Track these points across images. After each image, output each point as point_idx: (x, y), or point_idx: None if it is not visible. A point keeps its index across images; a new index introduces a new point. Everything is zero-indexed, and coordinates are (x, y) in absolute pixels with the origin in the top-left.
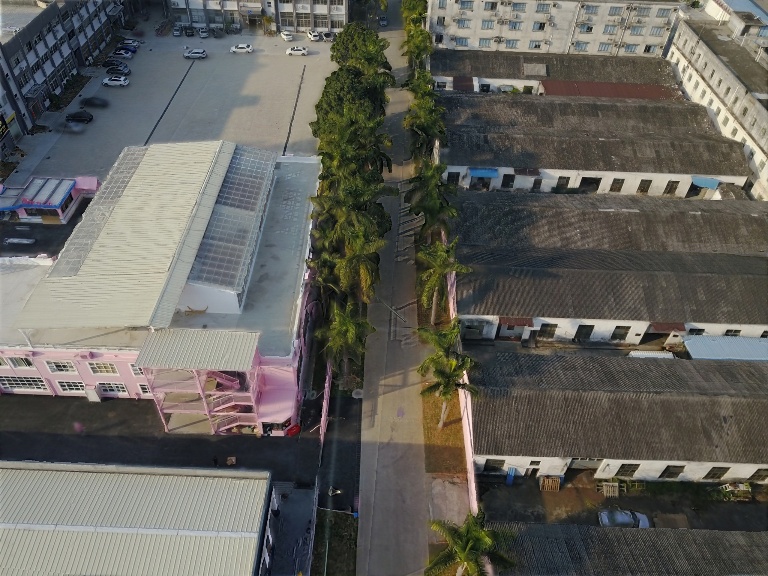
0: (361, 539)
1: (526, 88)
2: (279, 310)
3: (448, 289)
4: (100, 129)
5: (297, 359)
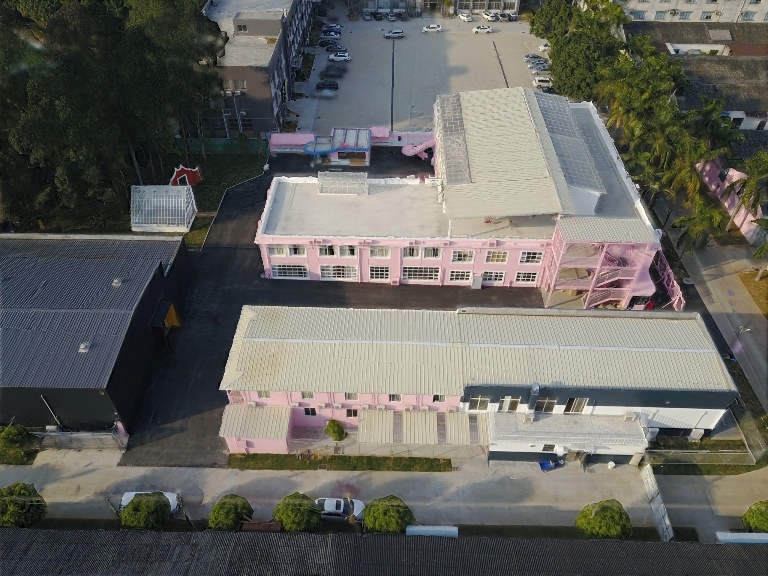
0: (749, 375)
1: (712, 52)
2: (624, 212)
3: (726, 205)
4: (347, 95)
5: (660, 244)
